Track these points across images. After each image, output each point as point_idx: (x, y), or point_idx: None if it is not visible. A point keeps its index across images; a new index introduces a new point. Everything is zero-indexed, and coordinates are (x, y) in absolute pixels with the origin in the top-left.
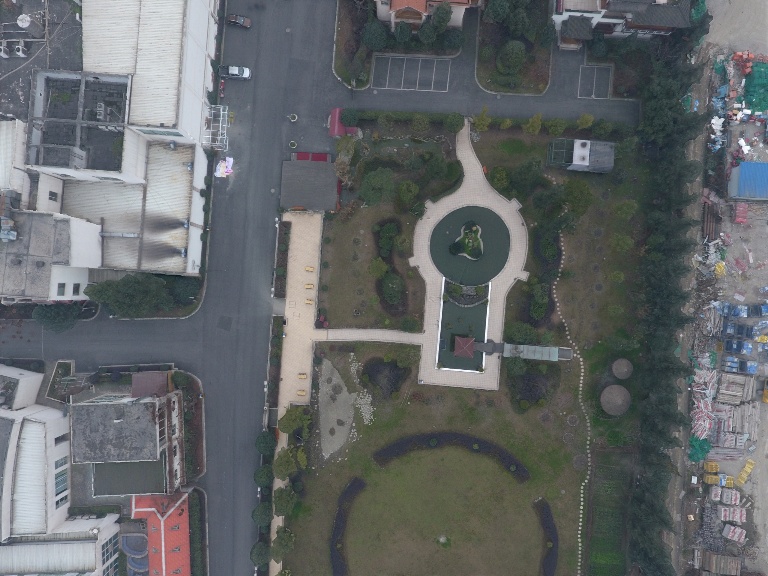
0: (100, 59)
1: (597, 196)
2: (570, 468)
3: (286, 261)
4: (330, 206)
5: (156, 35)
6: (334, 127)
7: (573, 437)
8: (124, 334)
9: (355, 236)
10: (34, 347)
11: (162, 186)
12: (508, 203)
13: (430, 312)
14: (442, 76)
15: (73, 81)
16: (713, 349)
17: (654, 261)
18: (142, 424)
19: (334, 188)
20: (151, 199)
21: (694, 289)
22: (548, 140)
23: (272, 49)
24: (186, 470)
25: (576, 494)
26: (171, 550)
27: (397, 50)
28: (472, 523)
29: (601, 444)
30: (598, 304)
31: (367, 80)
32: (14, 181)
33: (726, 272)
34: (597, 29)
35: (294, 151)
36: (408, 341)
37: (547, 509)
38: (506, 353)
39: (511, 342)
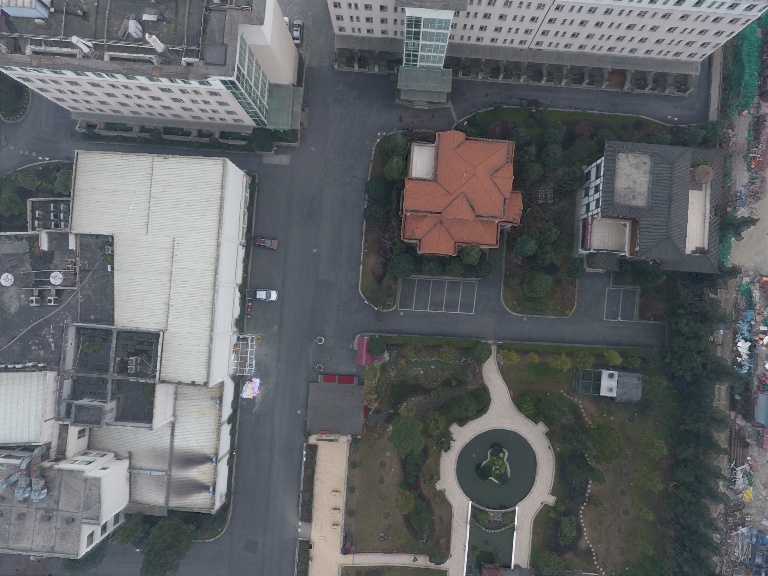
0: (132, 314)
1: (624, 419)
2: None
3: (312, 484)
4: (356, 429)
5: (188, 292)
6: (362, 357)
7: None
8: None
9: (381, 459)
10: (59, 568)
11: (190, 421)
12: (535, 426)
13: (456, 536)
14: (468, 298)
15: (104, 329)
16: (741, 575)
17: (683, 500)
18: None
19: (360, 411)
20: (179, 435)
21: (721, 514)
22: (574, 363)
23: (299, 269)
24: None
25: None
26: None
27: (424, 272)
28: None
29: None
30: (625, 529)
31: (394, 302)
32: (44, 434)
33: (753, 497)
34: (623, 255)
35: (321, 372)
36: (434, 566)
37: None
38: None
39: (538, 572)
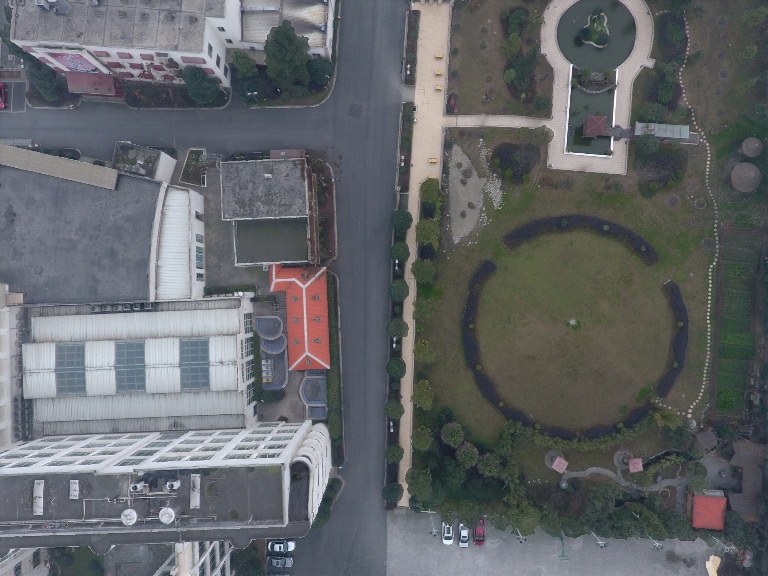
0: None
1: None
2: (698, 251)
3: (416, 49)
4: None
5: None
6: None
7: (701, 220)
8: (255, 122)
9: (483, 25)
10: (166, 136)
11: None
12: None
13: (558, 99)
14: None
15: None
16: None
17: None
18: (291, 181)
19: None
20: None
21: None
22: None
23: None
24: (320, 251)
25: (704, 276)
26: (312, 319)
27: None
28: (602, 305)
29: (729, 226)
30: (723, 90)
31: None
32: None
33: None
34: None
35: None
36: (536, 127)
37: (677, 289)
38: (637, 131)
39: None
